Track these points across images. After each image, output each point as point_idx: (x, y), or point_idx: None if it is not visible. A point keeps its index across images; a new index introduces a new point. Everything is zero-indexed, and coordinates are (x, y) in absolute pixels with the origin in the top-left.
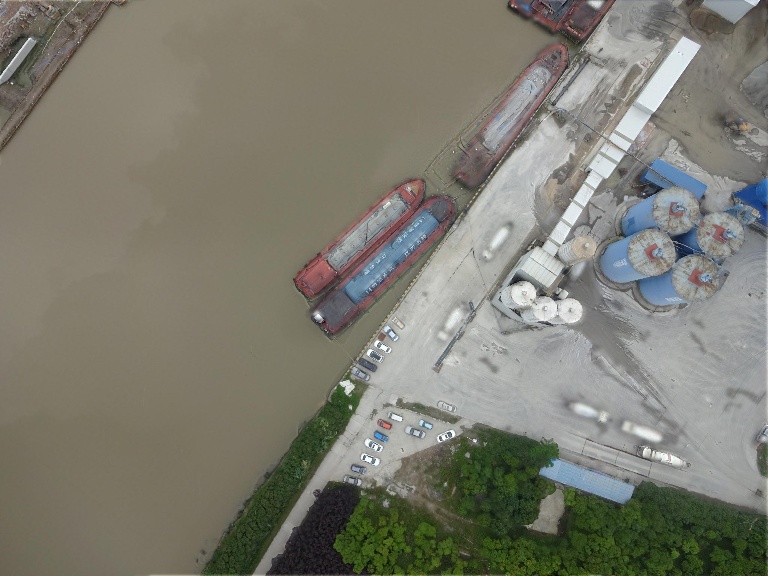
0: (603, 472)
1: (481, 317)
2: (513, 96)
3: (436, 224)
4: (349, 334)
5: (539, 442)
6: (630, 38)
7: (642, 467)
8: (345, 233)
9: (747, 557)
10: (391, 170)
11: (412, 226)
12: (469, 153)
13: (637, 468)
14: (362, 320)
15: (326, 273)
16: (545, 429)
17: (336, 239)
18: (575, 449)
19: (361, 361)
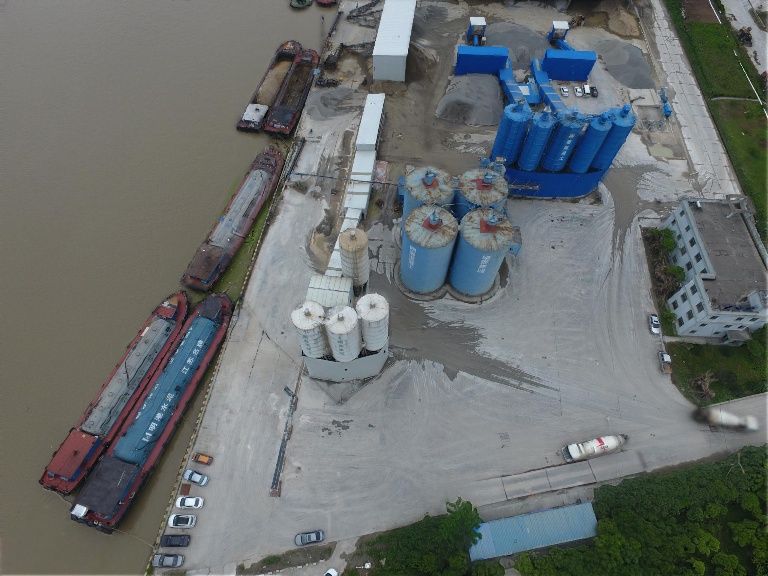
0: None
1: (305, 399)
2: (247, 186)
3: (210, 324)
4: (141, 512)
5: (447, 514)
6: (331, 117)
7: (582, 473)
8: (102, 386)
9: None
10: (143, 298)
11: (183, 339)
12: (222, 245)
13: (578, 478)
14: (158, 484)
15: (80, 444)
16: (447, 493)
17: (93, 399)
18: (496, 498)
19: (163, 540)
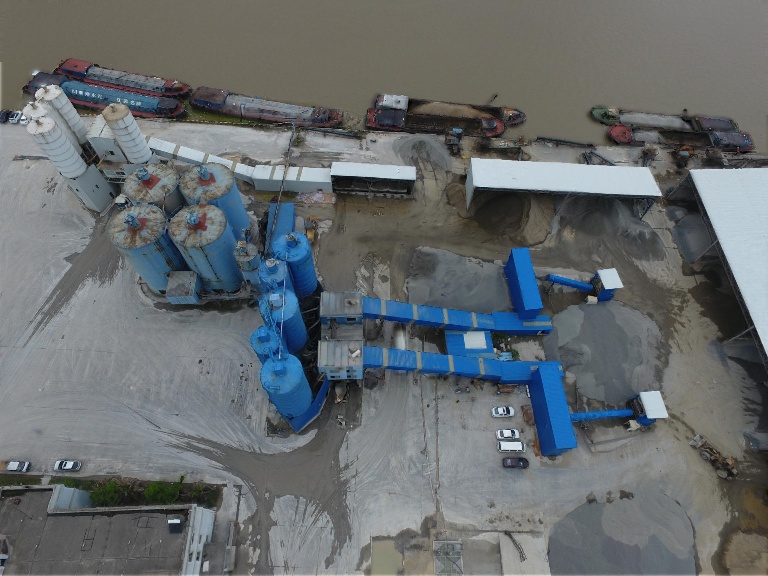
0: None
1: None
2: (293, 105)
3: (154, 105)
4: None
5: None
6: (400, 155)
7: None
8: None
9: None
10: None
11: None
12: (228, 101)
13: None
14: None
15: (81, 67)
16: None
17: None
18: None
19: (8, 111)
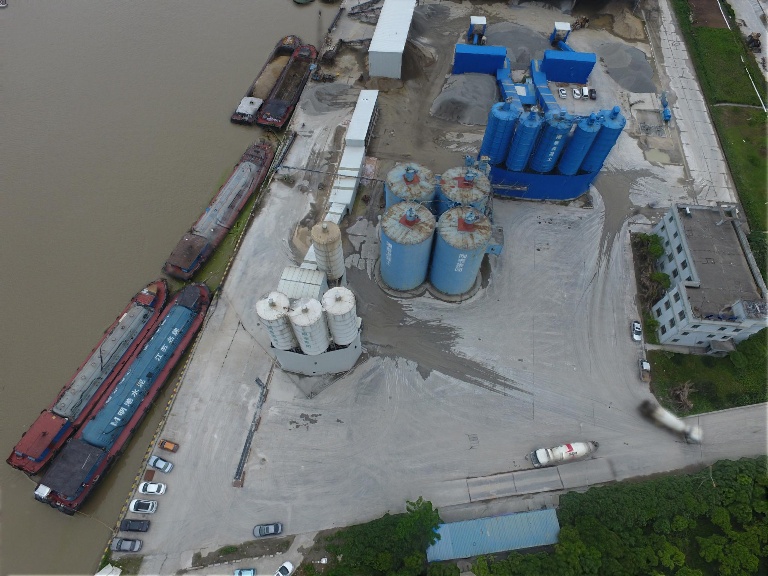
0: (510, 513)
1: (276, 391)
2: (234, 177)
3: (187, 312)
4: (105, 496)
5: (407, 513)
6: (325, 112)
7: (549, 479)
8: (77, 370)
9: (740, 529)
10: None
11: (159, 326)
12: (205, 235)
13: (545, 484)
14: (125, 469)
15: (50, 425)
16: (411, 493)
17: (67, 382)
18: (460, 499)
19: (123, 524)
